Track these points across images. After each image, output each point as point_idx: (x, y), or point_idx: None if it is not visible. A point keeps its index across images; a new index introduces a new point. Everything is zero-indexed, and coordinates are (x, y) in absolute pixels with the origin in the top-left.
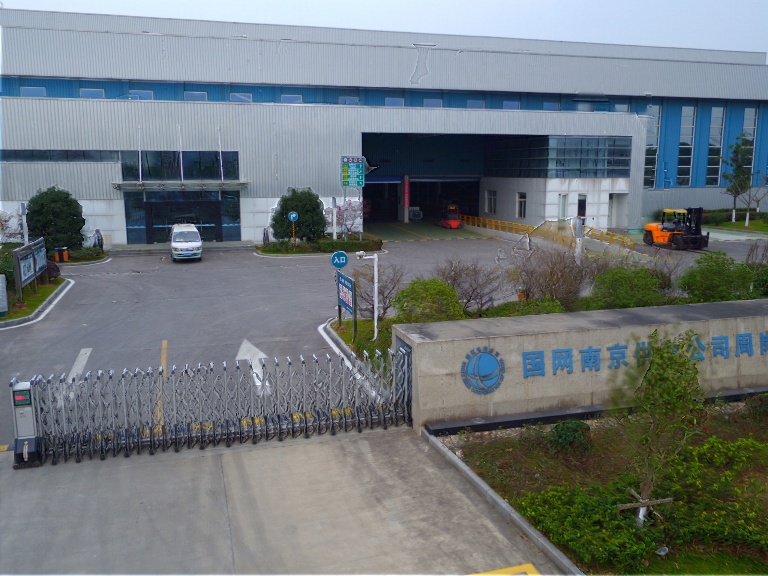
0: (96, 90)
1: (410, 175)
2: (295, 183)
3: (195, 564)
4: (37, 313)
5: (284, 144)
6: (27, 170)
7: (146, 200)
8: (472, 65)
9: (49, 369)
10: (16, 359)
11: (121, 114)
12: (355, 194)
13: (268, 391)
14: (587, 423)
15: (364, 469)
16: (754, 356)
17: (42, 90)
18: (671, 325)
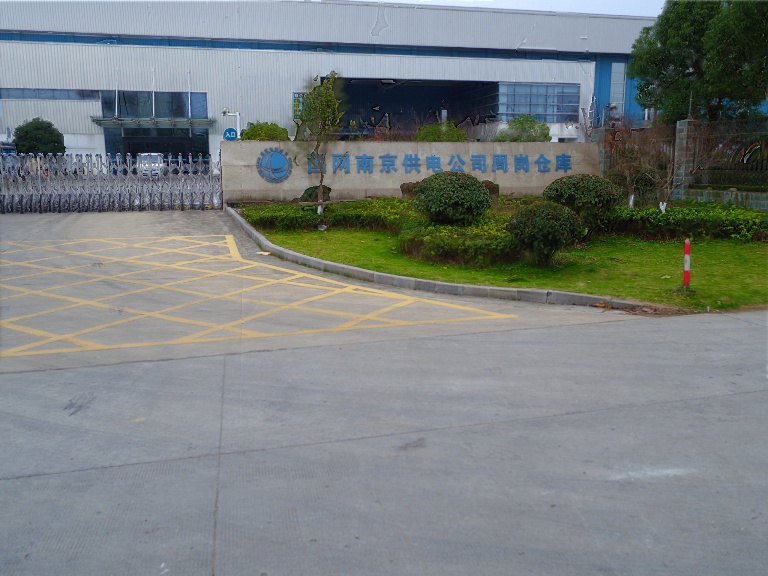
0: None
1: None
2: None
3: (11, 232)
4: None
5: (248, 86)
6: (18, 106)
7: (124, 135)
8: (438, 22)
9: None
10: None
11: (101, 57)
12: None
13: (112, 176)
14: None
15: (166, 217)
16: (509, 173)
17: None
18: (435, 143)
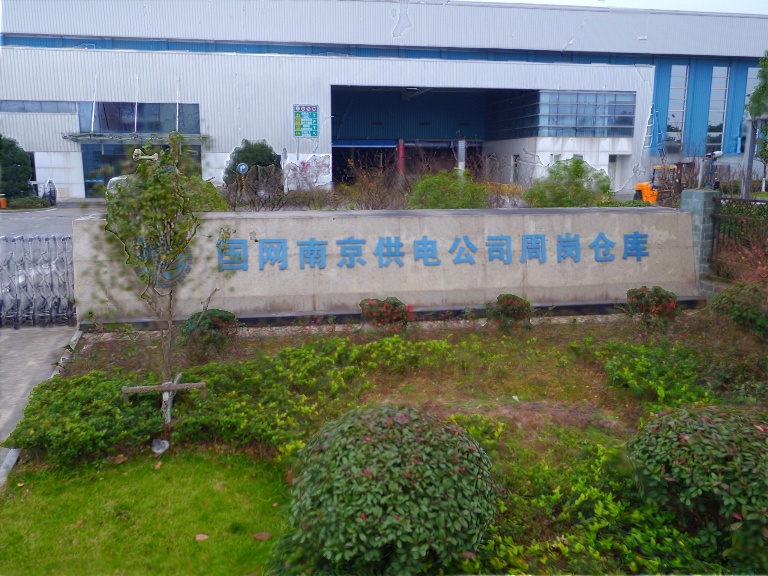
0: None
1: (405, 139)
2: (259, 138)
3: None
4: None
5: (247, 96)
6: None
7: (104, 153)
8: (471, 21)
9: None
10: None
11: (77, 64)
12: (324, 150)
13: None
14: (292, 329)
15: None
16: (548, 263)
17: None
18: (429, 218)
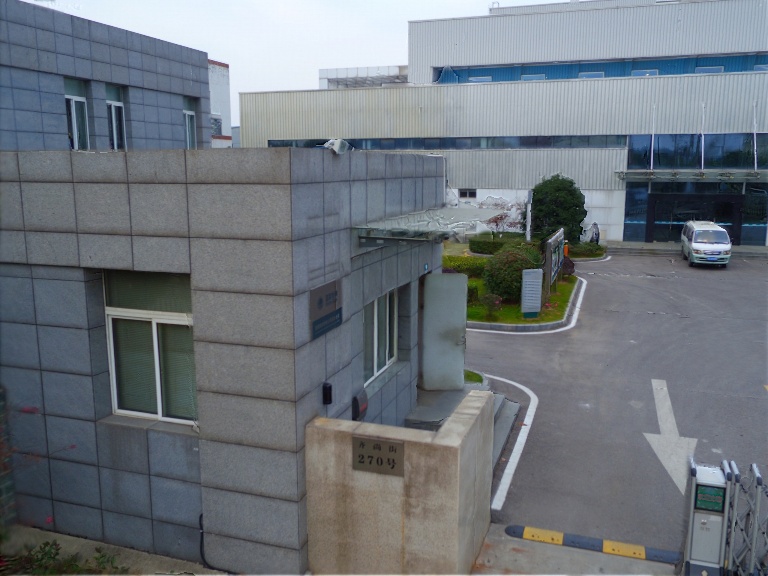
0: (596, 73)
1: None
2: None
3: None
4: (567, 317)
5: None
6: (529, 157)
7: (651, 192)
8: None
9: (625, 405)
10: (574, 380)
11: (635, 93)
12: None
13: None
14: None
15: None
16: None
17: (542, 77)
18: None
